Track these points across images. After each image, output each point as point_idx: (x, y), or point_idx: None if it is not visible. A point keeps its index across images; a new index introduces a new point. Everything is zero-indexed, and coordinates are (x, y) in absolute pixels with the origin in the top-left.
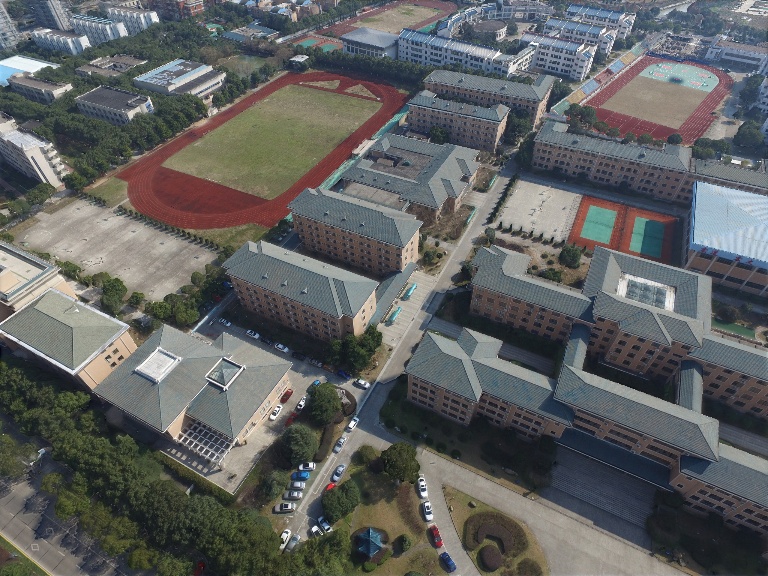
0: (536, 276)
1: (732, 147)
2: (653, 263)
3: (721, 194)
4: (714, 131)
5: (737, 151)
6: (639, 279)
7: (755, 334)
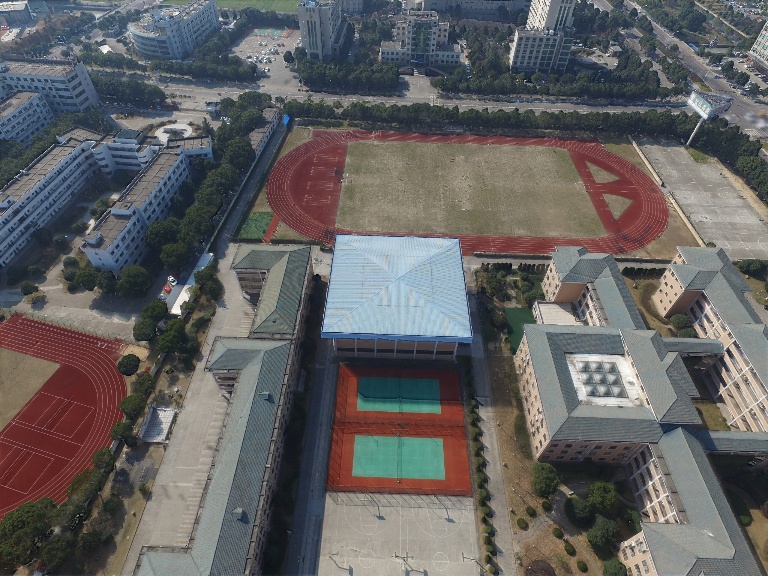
0: (675, 507)
1: (125, 303)
2: (554, 372)
3: (348, 310)
4: (69, 320)
5: (138, 298)
6: (578, 386)
7: (508, 307)
